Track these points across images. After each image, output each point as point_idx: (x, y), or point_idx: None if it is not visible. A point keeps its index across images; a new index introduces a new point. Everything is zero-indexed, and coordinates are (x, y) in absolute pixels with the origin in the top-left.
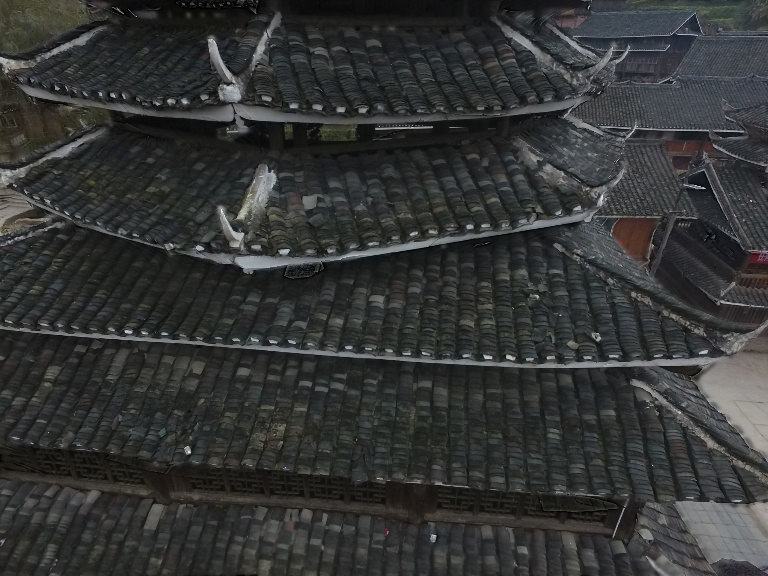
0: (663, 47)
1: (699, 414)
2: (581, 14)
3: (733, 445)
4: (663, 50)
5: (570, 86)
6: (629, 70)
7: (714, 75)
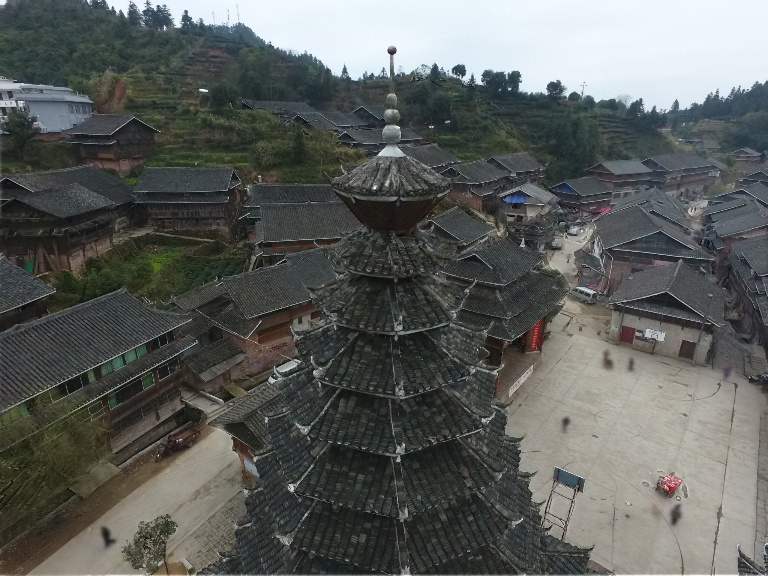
0: (225, 199)
1: (584, 573)
2: (122, 158)
3: (594, 575)
4: (226, 201)
5: (537, 512)
6: (203, 216)
7: (289, 236)
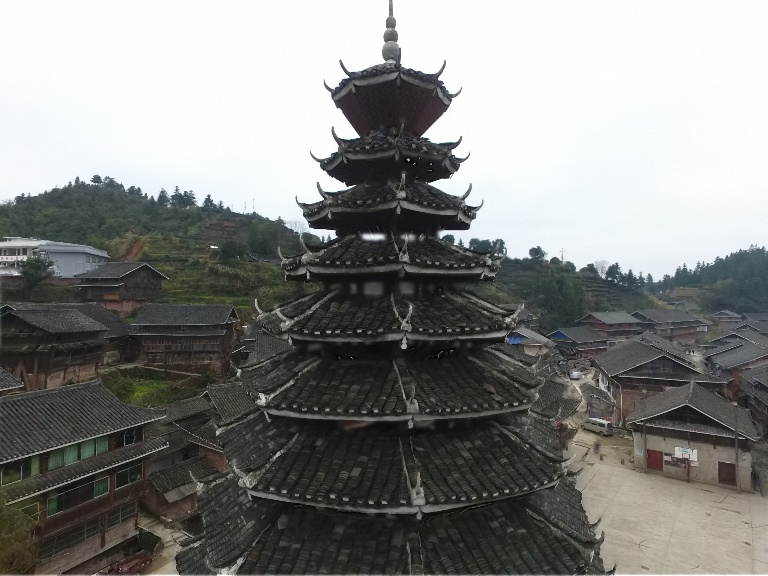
0: (221, 332)
1: None
2: (126, 299)
3: None
4: (222, 334)
5: None
6: (197, 349)
7: None
